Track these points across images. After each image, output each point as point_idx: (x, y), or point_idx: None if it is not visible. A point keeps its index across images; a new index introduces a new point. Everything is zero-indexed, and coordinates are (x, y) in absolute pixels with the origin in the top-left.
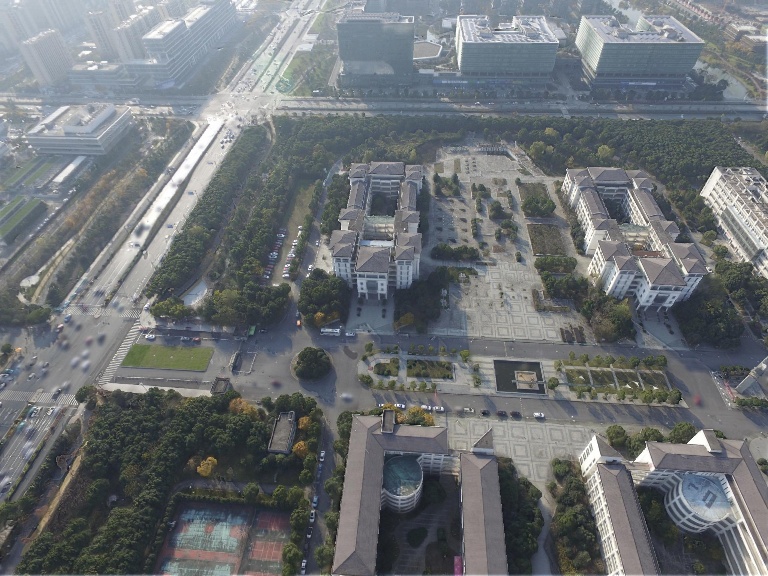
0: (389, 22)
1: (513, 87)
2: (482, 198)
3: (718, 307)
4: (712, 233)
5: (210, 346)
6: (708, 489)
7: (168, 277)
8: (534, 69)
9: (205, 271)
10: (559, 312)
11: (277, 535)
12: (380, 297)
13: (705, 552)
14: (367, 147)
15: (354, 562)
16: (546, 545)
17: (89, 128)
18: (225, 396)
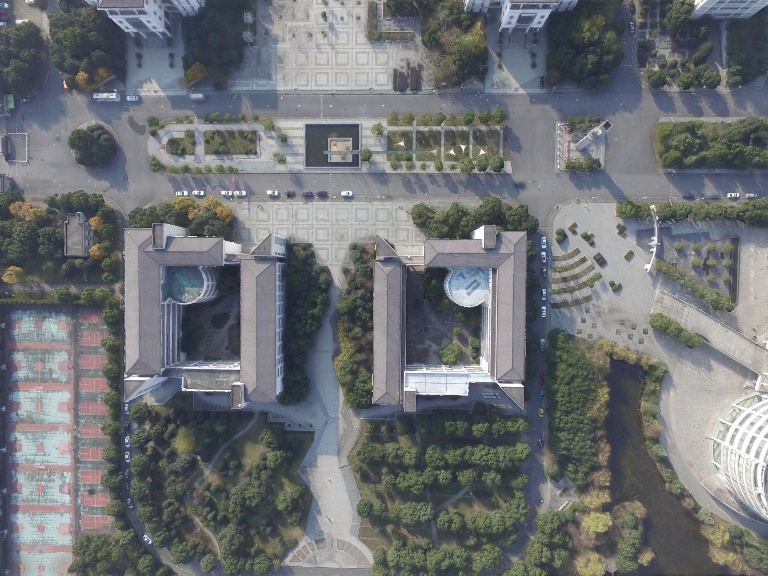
0: None
1: None
2: None
3: (595, 31)
4: None
5: None
6: (475, 278)
7: None
8: None
9: None
10: (398, 41)
11: (99, 326)
12: (161, 34)
13: (465, 320)
14: None
15: (141, 366)
16: (332, 320)
17: None
18: (1, 201)
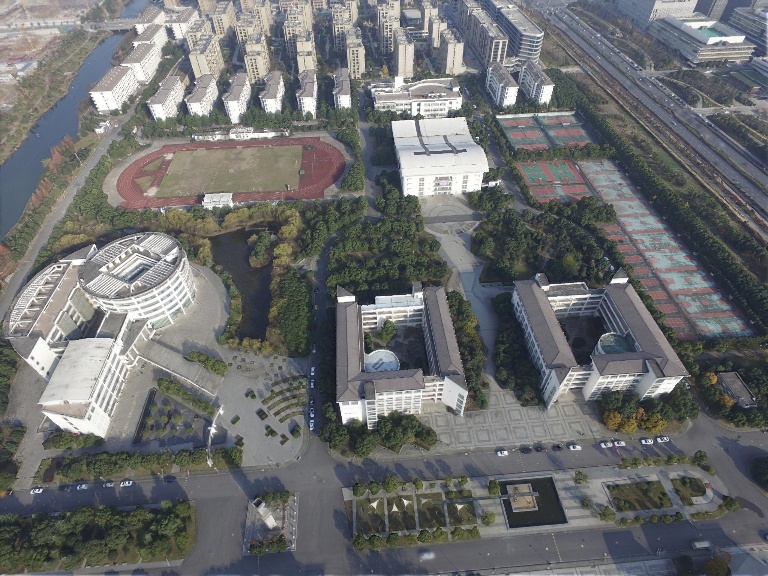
0: None
1: None
2: None
3: None
4: None
5: None
6: None
7: None
8: None
9: None
10: None
11: None
12: None
13: None
14: None
15: (621, 287)
16: (487, 351)
17: None
18: None
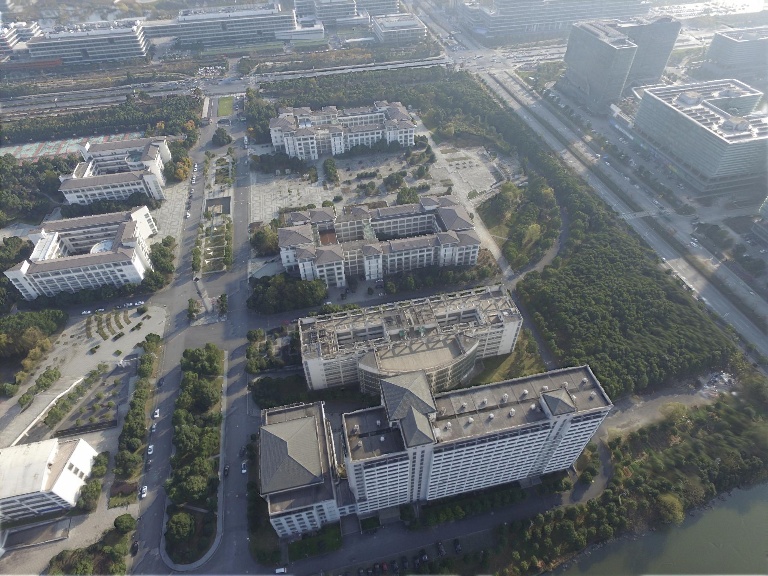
0: (603, 39)
1: (669, 173)
2: (413, 175)
3: (273, 279)
4: (404, 304)
5: (234, 113)
6: None
7: (271, 85)
8: (693, 162)
9: (288, 98)
10: None
11: None
12: None
13: None
14: (451, 113)
15: None
16: None
17: (388, 24)
18: None
